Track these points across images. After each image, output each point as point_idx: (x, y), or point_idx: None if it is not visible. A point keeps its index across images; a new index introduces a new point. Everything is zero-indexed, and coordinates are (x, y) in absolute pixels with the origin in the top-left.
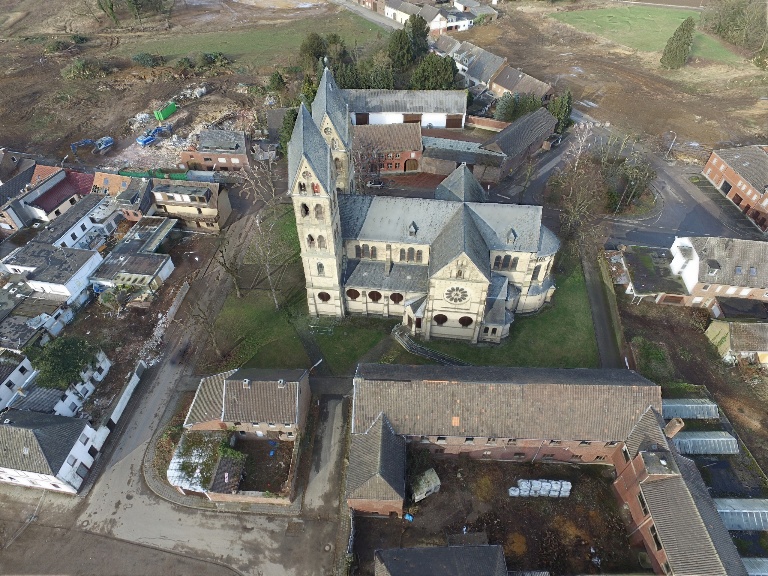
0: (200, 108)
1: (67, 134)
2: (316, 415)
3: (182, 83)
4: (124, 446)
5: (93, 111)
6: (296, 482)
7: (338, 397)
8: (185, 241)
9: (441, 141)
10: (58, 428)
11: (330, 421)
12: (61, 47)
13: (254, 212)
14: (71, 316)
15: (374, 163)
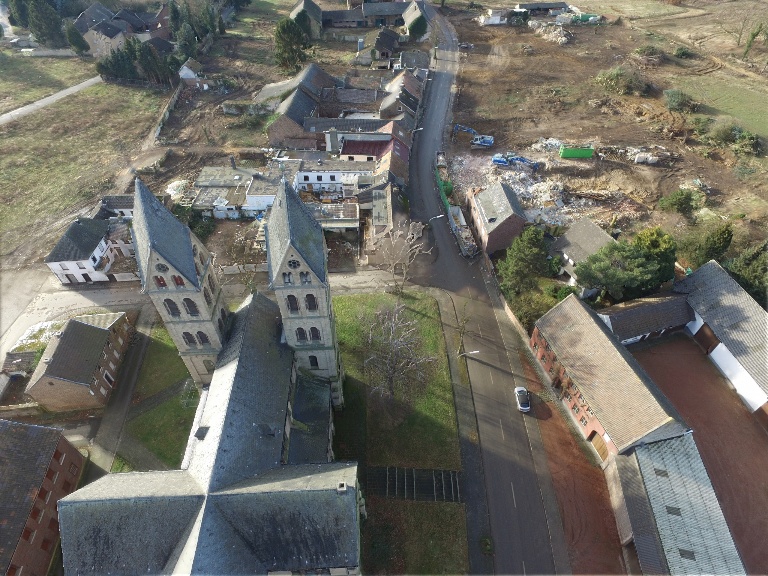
0: (614, 172)
1: (494, 118)
2: (76, 418)
3: (657, 140)
4: (96, 293)
5: (545, 114)
6: (7, 418)
7: (92, 434)
8: (344, 245)
9: (691, 487)
10: (73, 246)
11: (63, 432)
12: (647, 52)
13: (411, 281)
14: (237, 216)
15: (562, 382)
